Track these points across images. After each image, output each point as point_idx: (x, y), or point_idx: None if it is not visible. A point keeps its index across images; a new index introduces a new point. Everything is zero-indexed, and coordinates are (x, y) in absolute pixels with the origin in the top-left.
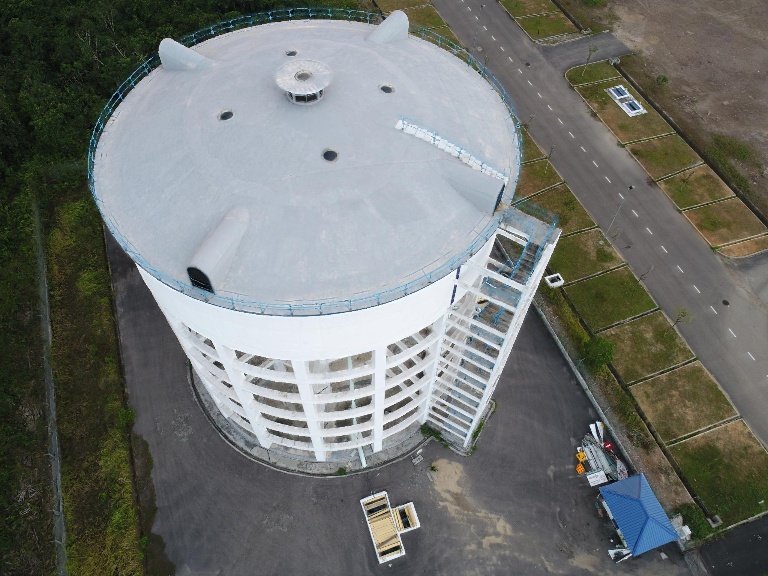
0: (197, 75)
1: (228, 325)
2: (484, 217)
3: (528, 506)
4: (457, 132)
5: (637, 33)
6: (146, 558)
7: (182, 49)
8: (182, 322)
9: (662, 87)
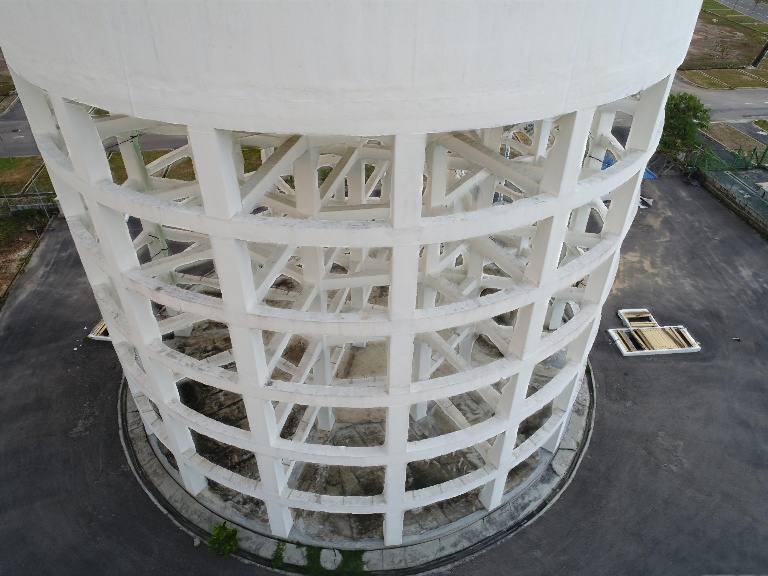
0: None
1: None
2: None
3: None
4: None
5: None
6: None
7: None
8: (641, 87)
9: None
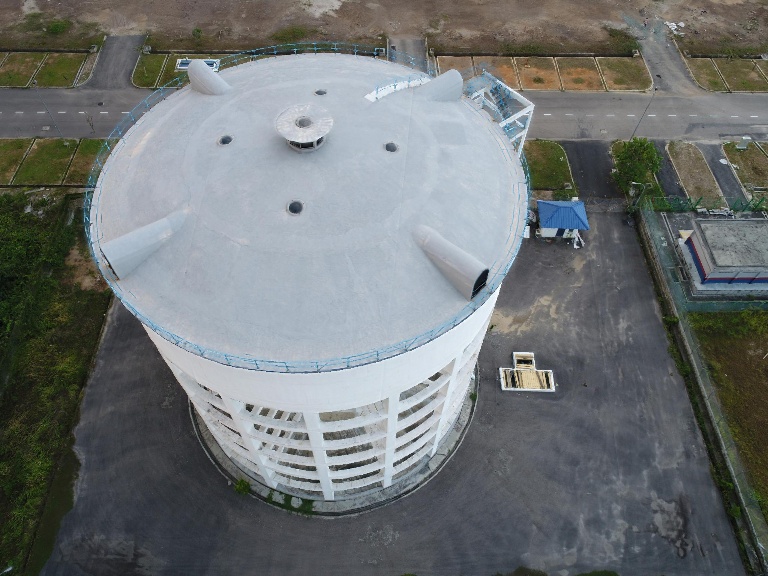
0: (192, 230)
1: (480, 313)
2: (461, 102)
3: (534, 280)
4: (380, 78)
5: (125, 22)
6: None
7: (136, 234)
8: None
9: (200, 38)
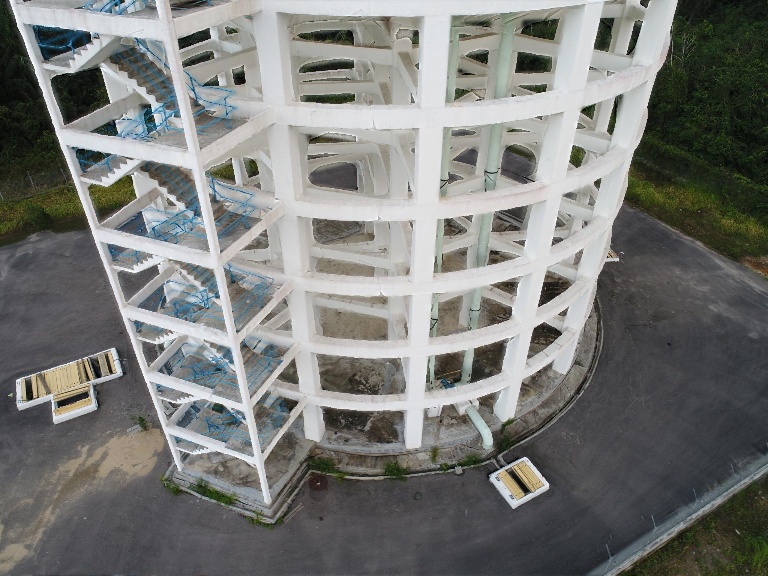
0: None
1: None
2: None
3: None
4: None
5: None
6: (100, 212)
7: None
8: None
9: None
